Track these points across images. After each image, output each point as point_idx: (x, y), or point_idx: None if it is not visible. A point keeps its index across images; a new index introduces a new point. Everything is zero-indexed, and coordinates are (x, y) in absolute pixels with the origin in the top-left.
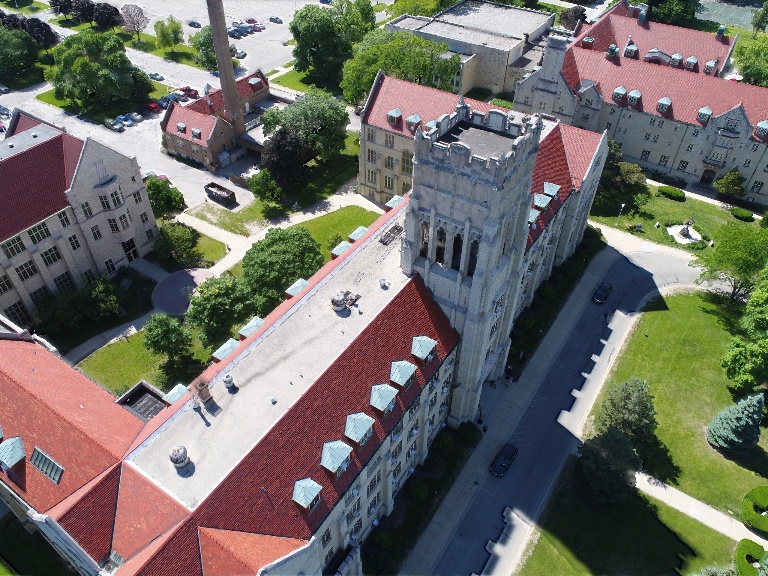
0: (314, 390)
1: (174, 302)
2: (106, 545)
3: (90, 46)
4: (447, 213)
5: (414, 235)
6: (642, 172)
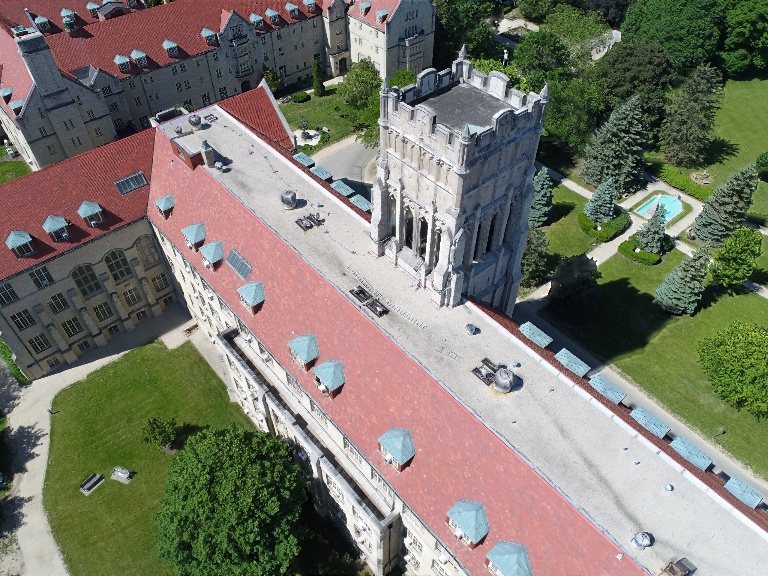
0: None
1: None
2: None
3: None
4: (488, 200)
5: (462, 256)
6: None
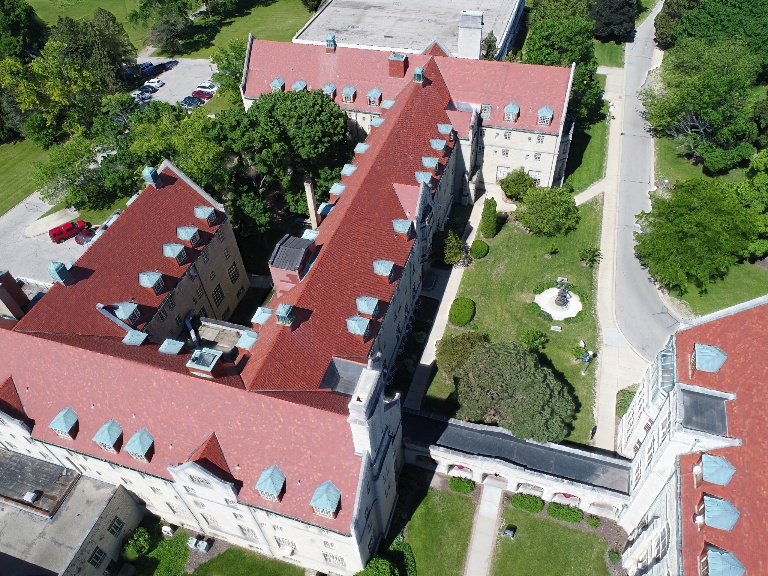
0: None
1: None
2: None
3: None
4: None
5: None
6: (418, 343)
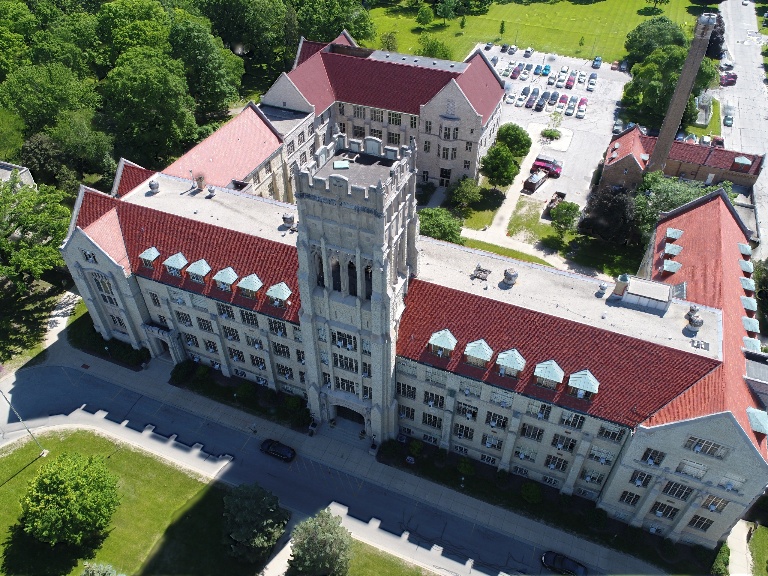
0: (205, 226)
1: None
2: (124, 192)
3: (673, 59)
4: None
5: None
6: None
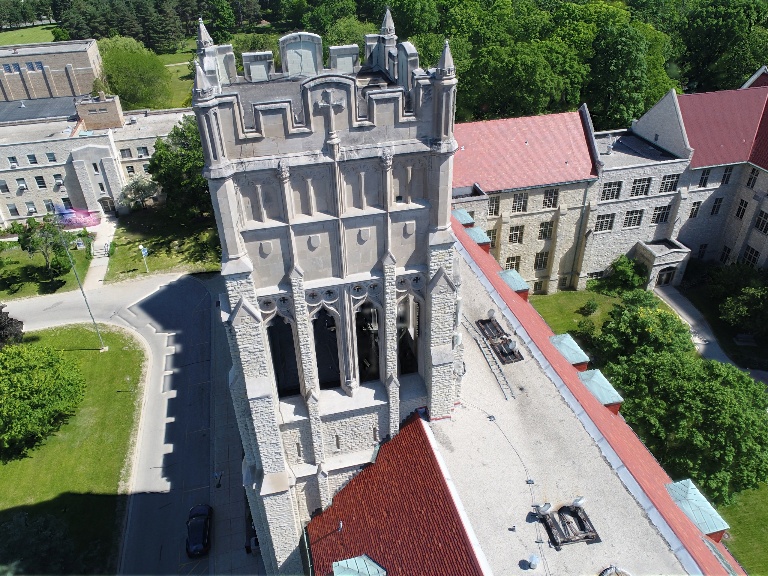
0: None
1: None
2: None
3: None
4: None
5: None
6: None
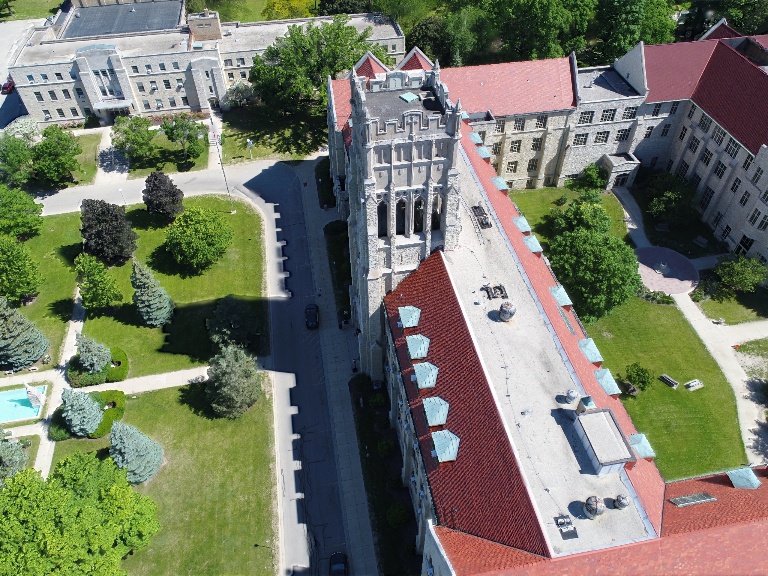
0: None
1: (651, 256)
2: None
3: None
4: None
5: None
6: None
